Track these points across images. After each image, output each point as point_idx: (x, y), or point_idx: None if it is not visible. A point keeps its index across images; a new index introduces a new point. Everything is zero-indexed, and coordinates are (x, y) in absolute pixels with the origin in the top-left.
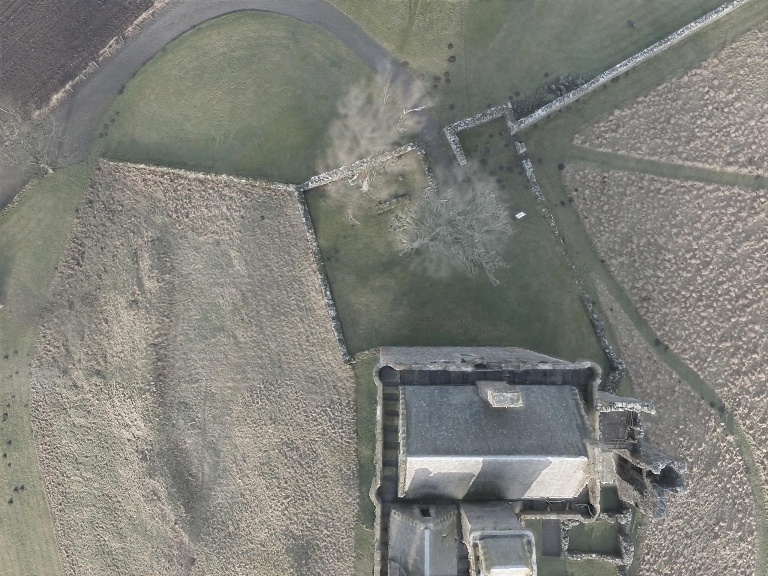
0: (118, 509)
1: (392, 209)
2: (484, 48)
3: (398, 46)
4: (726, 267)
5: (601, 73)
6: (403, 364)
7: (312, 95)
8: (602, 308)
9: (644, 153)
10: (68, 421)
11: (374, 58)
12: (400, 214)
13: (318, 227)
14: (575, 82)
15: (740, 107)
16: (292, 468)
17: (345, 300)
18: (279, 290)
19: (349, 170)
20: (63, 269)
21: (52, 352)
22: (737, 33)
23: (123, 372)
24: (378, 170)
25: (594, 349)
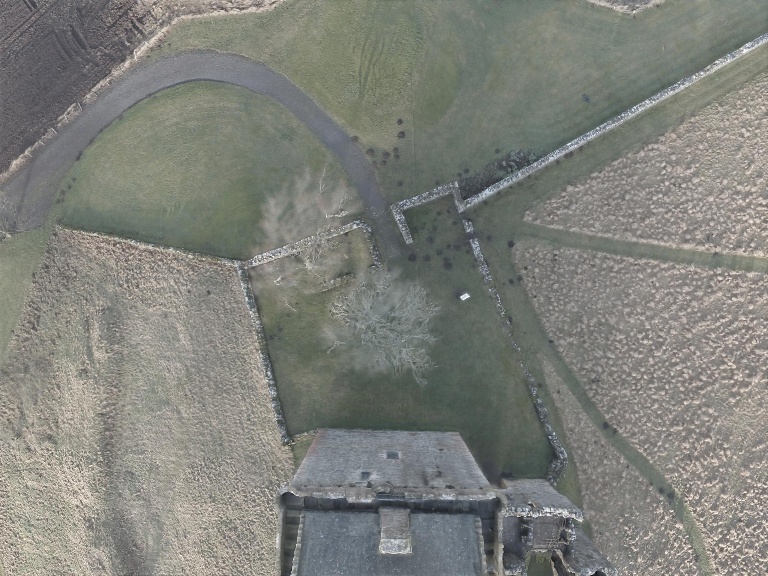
0: (67, 573)
1: (336, 287)
2: (434, 124)
3: (348, 120)
4: (680, 348)
5: (554, 149)
6: (306, 489)
7: (262, 168)
8: (548, 391)
9: (597, 230)
10: (21, 483)
11: (324, 132)
12: (335, 303)
13: (262, 305)
14: (526, 158)
15: (698, 183)
16: (230, 548)
17: (286, 380)
18: (222, 367)
19: (293, 248)
20: (19, 332)
21: (7, 414)
22: (696, 107)
23: (72, 439)
24: (323, 247)
25: (537, 435)
